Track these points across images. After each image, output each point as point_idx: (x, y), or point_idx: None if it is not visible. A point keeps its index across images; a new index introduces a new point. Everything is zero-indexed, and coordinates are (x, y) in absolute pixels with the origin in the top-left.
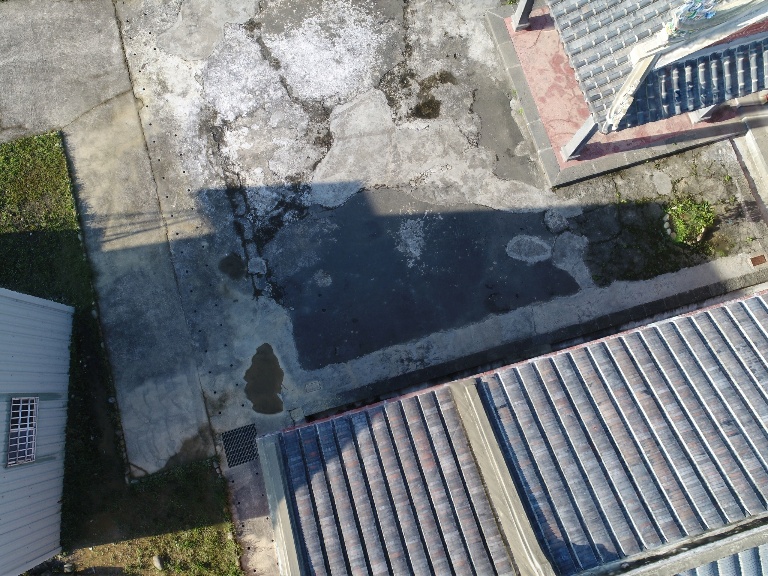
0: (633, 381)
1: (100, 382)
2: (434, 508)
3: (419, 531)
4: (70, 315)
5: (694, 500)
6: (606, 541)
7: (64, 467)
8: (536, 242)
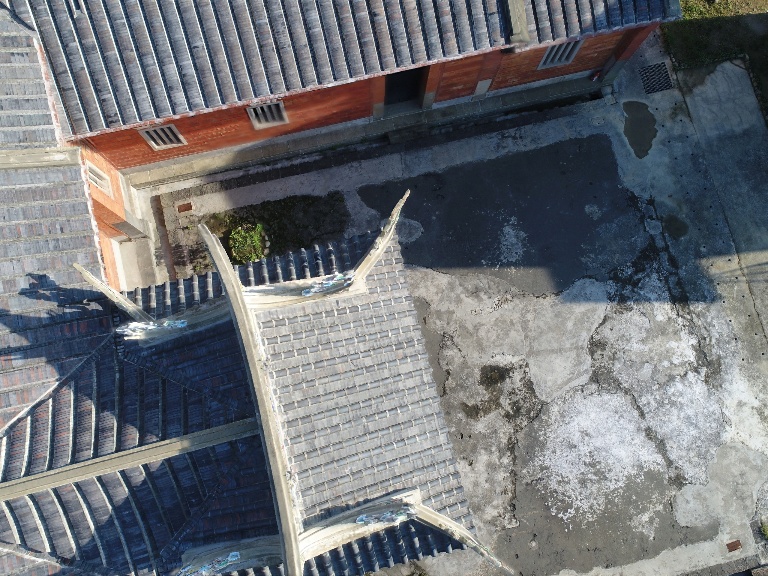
0: (383, 26)
1: None
2: None
3: None
4: None
5: None
6: None
7: None
8: None
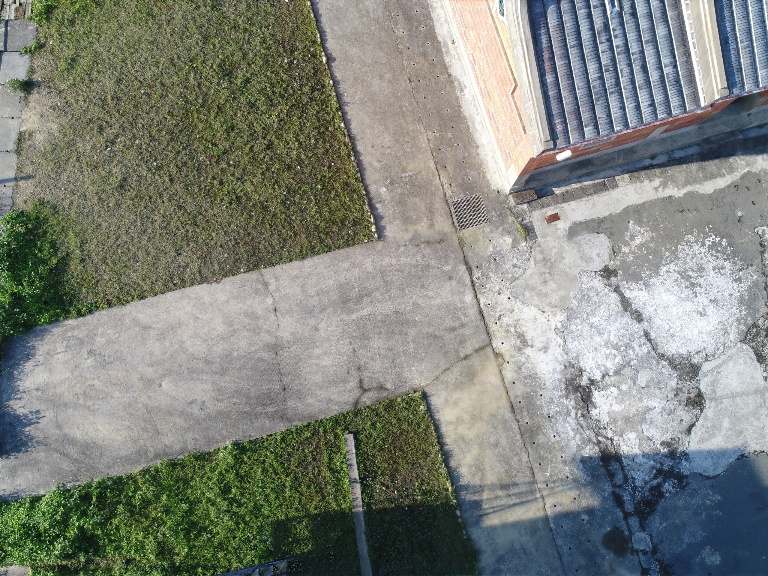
0: None
1: None
2: None
3: None
4: None
5: None
6: None
7: None
8: None
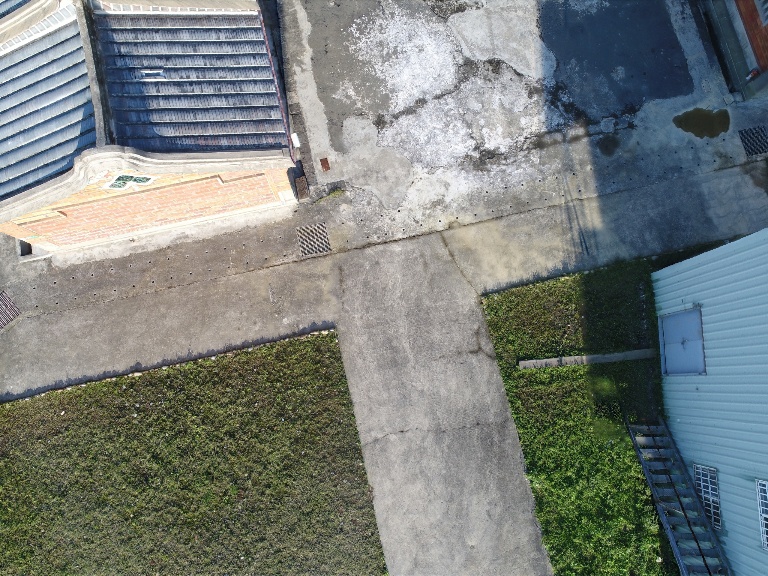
0: None
1: None
2: None
3: None
4: None
5: None
6: None
7: None
8: None
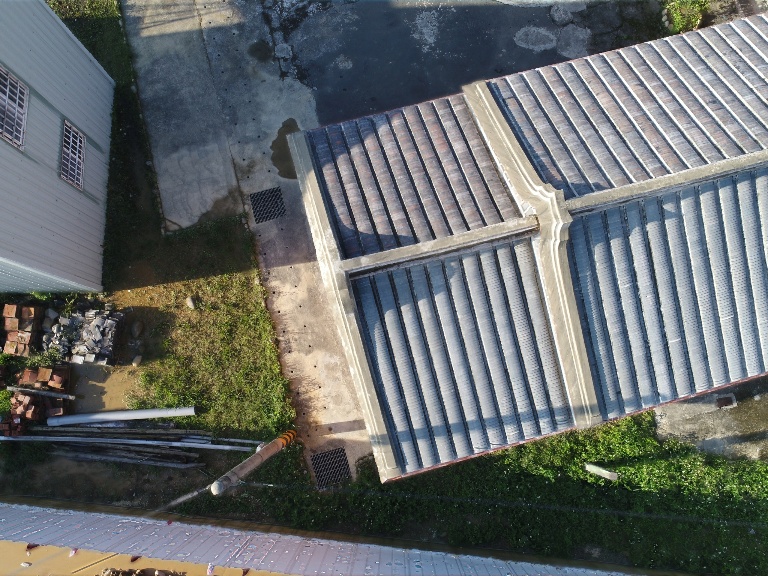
0: (628, 78)
1: (138, 148)
2: (447, 177)
3: (434, 193)
4: (112, 87)
5: (681, 153)
6: (601, 180)
7: (106, 218)
8: (542, 33)
